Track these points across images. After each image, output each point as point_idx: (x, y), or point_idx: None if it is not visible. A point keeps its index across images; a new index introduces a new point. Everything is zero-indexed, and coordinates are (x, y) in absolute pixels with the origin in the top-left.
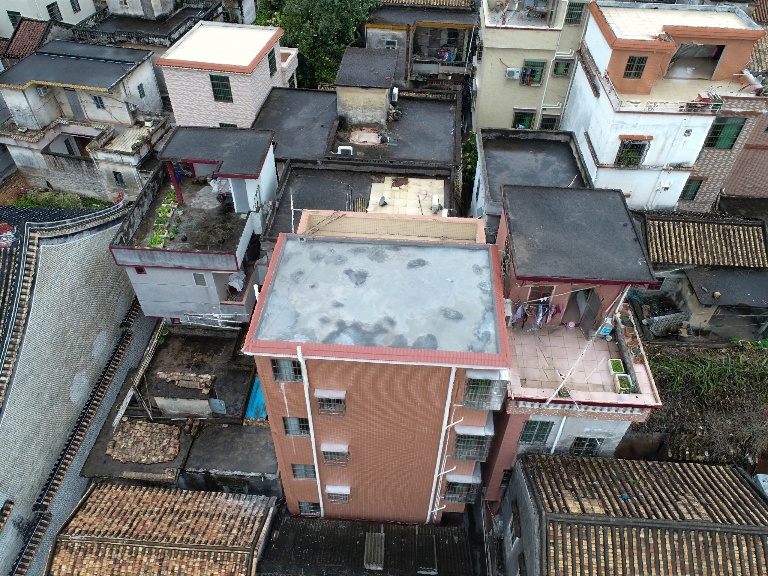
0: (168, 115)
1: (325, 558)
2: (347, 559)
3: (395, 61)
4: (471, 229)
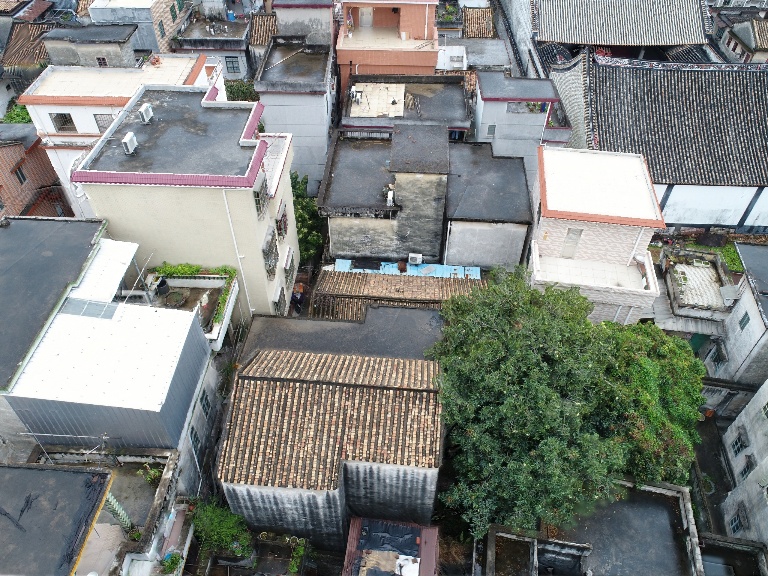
0: (680, 304)
1: None
2: None
3: (392, 153)
4: (342, 54)
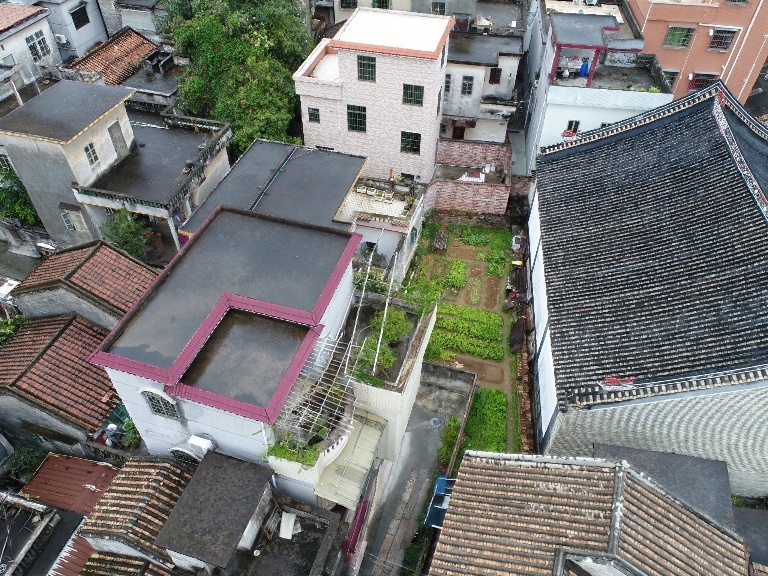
0: None
1: (764, 102)
2: (760, 97)
3: None
4: None
